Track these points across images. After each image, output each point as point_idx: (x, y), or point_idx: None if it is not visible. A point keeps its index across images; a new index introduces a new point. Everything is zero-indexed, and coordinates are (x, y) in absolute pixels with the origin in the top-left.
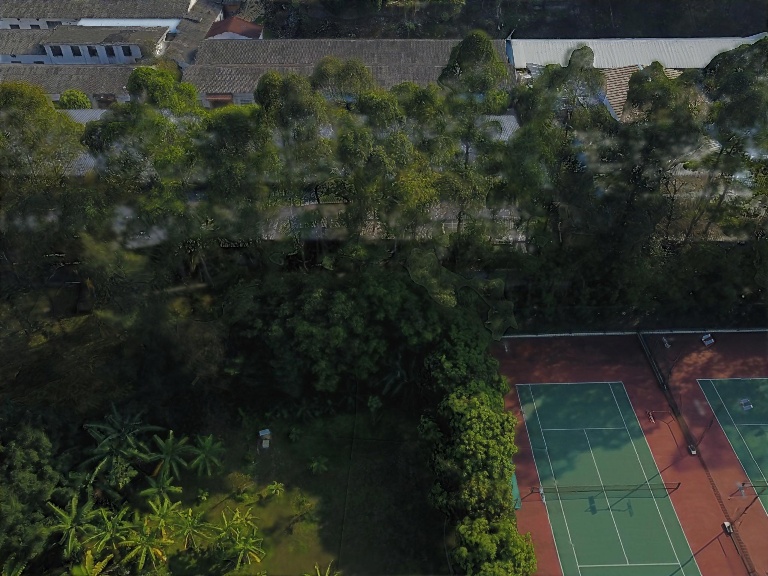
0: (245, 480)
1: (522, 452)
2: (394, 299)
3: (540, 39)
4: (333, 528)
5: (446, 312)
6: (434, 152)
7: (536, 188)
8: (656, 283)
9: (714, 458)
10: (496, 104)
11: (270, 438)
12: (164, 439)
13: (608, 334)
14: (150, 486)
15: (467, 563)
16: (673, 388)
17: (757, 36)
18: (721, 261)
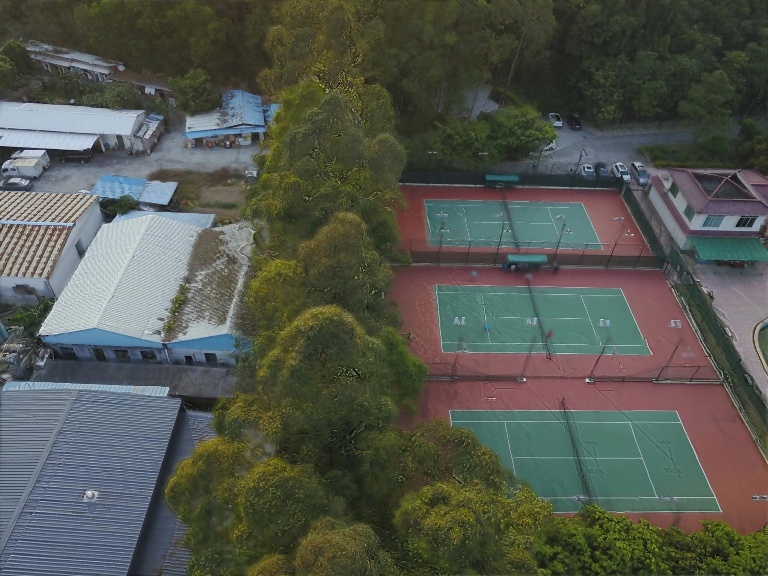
0: None
1: None
2: None
3: None
4: None
5: None
6: None
7: None
8: None
9: (527, 368)
10: None
11: None
12: None
13: None
14: None
15: None
16: (455, 372)
17: None
18: None
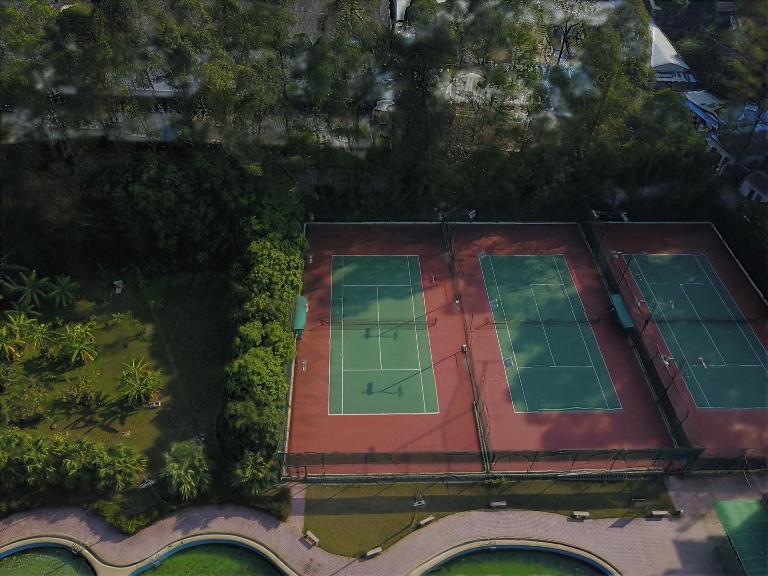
0: (90, 306)
1: (323, 299)
2: (216, 171)
3: None
4: (159, 345)
5: (263, 186)
6: (238, 48)
7: (324, 82)
8: (451, 178)
9: (472, 305)
10: None
11: (123, 287)
12: (28, 276)
13: (418, 223)
14: (13, 309)
15: (240, 349)
16: (457, 260)
17: None
18: (496, 158)
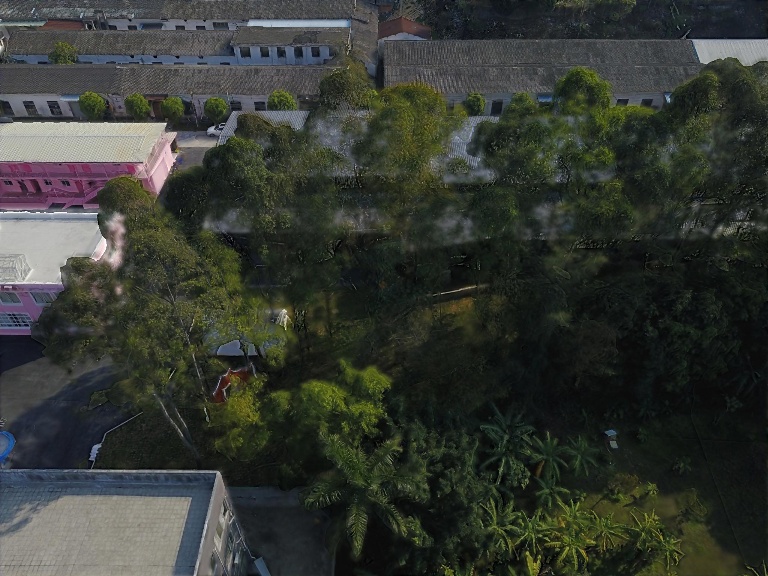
0: (635, 481)
1: None
2: (765, 300)
3: (714, 39)
4: (722, 529)
5: None
6: None
7: None
8: None
9: None
10: None
11: (616, 439)
12: (542, 440)
13: None
14: (541, 487)
15: None
16: None
17: None
18: None
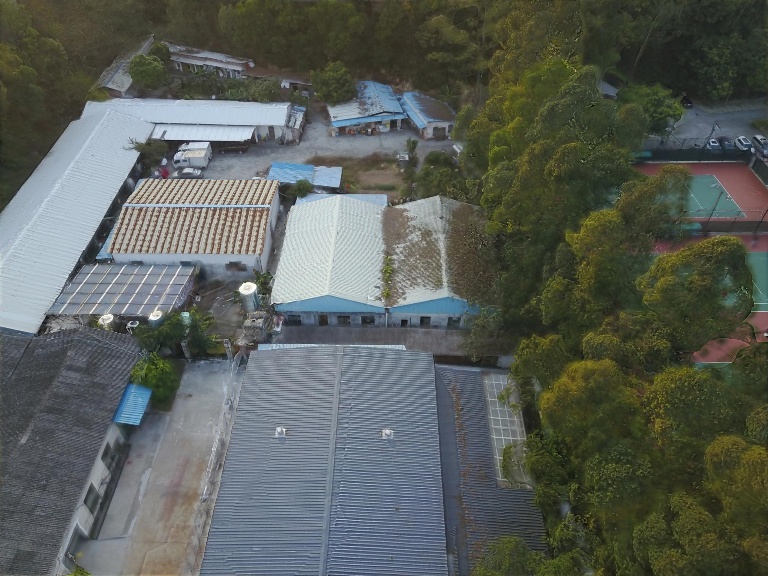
0: None
1: None
2: None
3: None
4: None
5: None
6: None
7: None
8: None
9: None
10: (169, 373)
11: None
12: None
13: None
14: None
15: None
16: None
17: (89, 109)
18: None
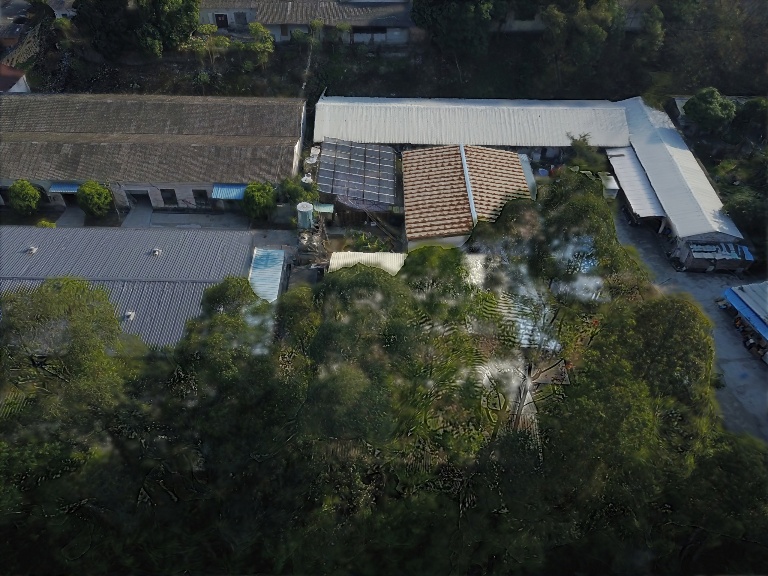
0: None
1: None
2: None
3: (362, 99)
4: None
5: None
6: None
7: None
8: None
9: None
10: (256, 203)
11: None
12: None
13: None
14: None
15: None
16: None
17: (628, 101)
18: (406, 544)
